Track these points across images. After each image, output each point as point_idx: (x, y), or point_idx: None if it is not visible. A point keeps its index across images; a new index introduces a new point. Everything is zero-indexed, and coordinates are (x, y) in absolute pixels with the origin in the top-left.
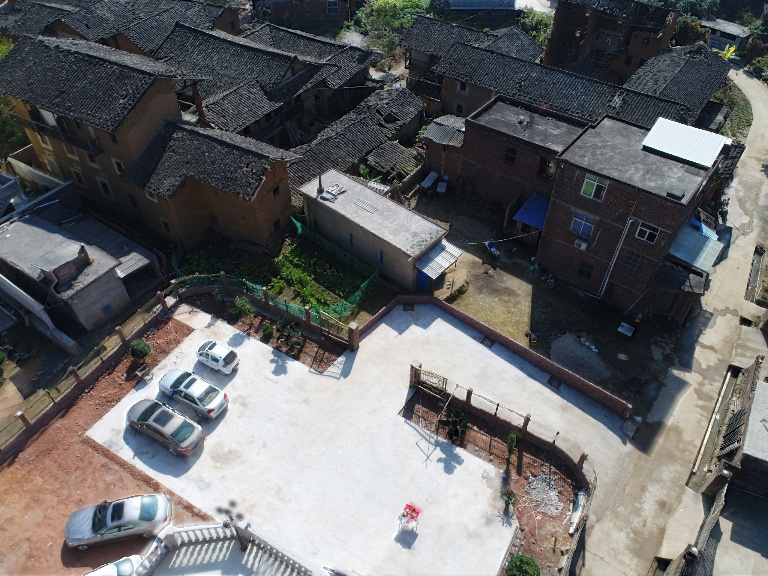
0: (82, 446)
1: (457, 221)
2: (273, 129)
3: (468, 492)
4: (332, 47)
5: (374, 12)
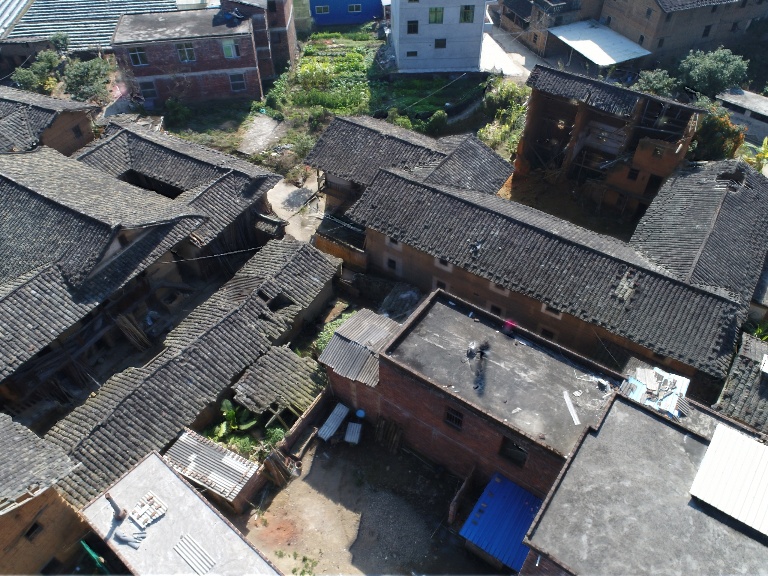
0: None
1: (373, 510)
2: (93, 334)
3: None
4: (210, 169)
5: (300, 78)
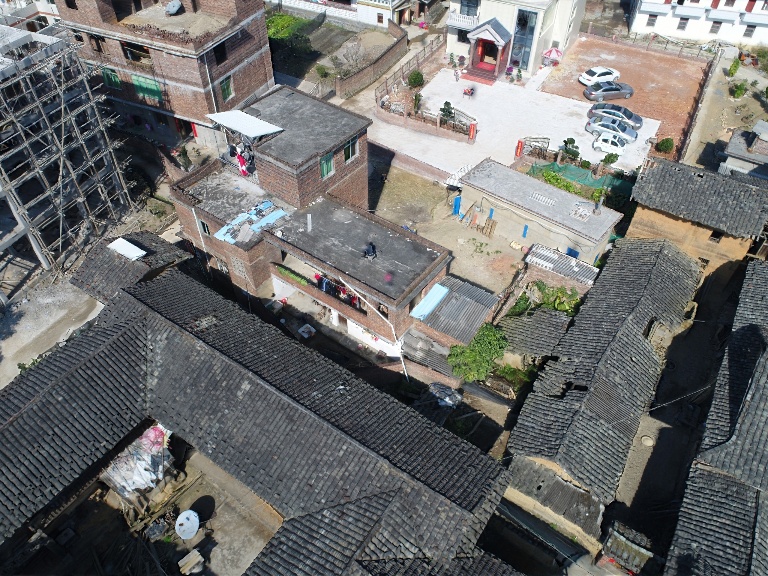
0: (657, 118)
1: None
2: None
3: (438, 105)
4: None
5: None
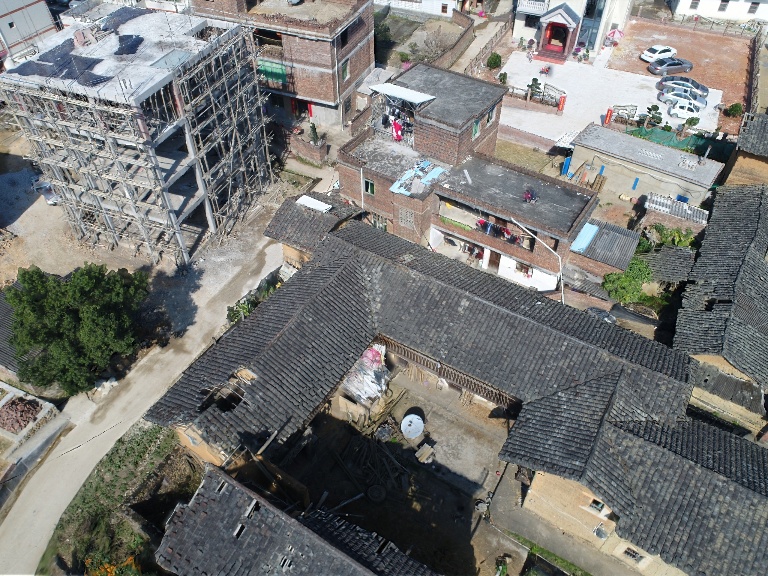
0: (719, 88)
1: None
2: None
3: (520, 83)
4: None
5: None
